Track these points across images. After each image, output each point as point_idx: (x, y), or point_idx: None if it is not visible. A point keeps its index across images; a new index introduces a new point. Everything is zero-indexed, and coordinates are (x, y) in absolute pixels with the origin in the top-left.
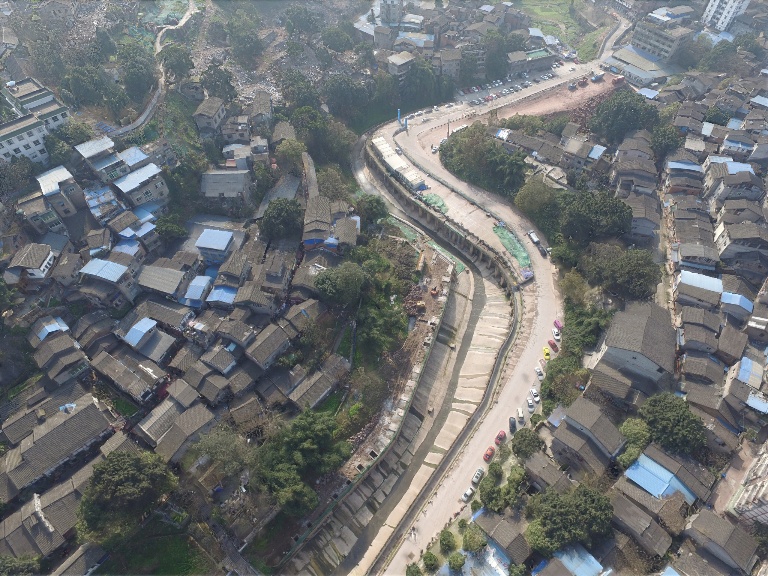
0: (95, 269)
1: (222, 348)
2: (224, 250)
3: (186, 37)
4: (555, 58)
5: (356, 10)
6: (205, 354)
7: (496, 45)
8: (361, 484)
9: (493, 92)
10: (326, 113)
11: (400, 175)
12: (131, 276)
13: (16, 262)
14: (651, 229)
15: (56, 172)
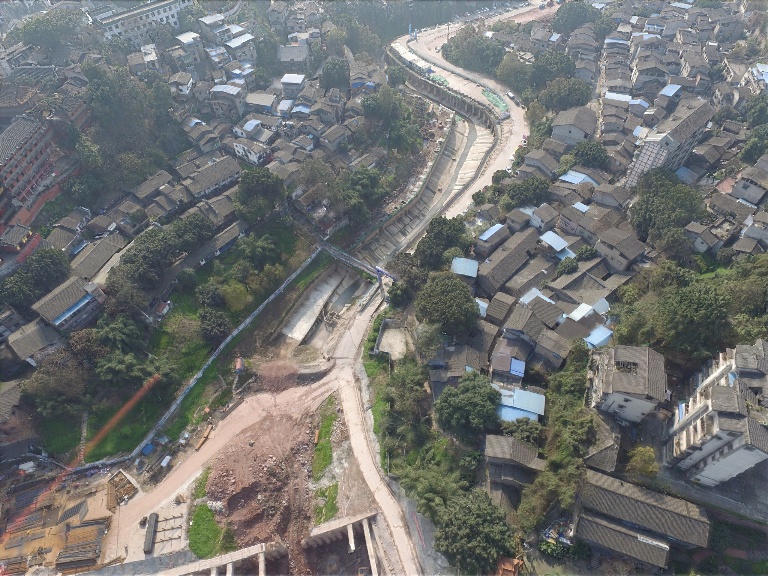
0: (220, 88)
1: (305, 135)
2: (300, 84)
3: None
4: None
5: None
6: (294, 139)
7: None
8: (396, 221)
9: (482, 15)
10: (356, 23)
11: (413, 65)
12: (241, 97)
13: (173, 80)
14: (590, 77)
15: (187, 34)
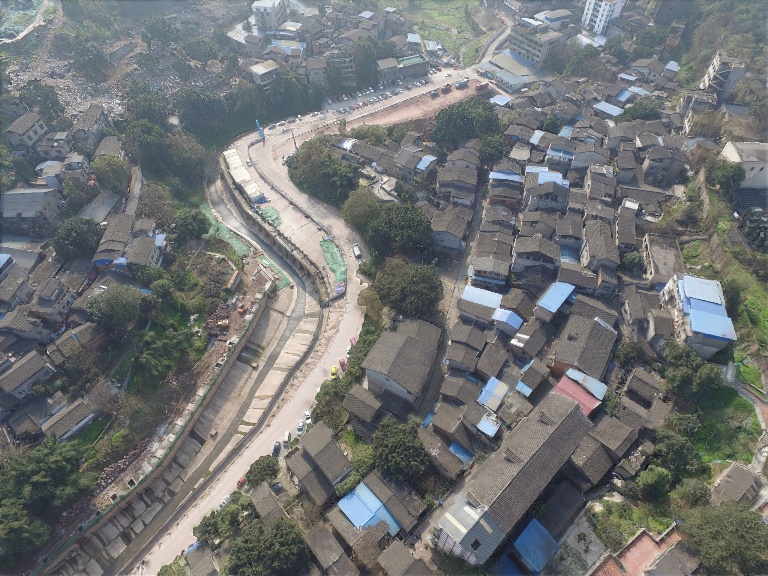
0: None
1: None
2: None
3: (25, 50)
4: (432, 64)
5: (234, 18)
6: None
7: (362, 52)
8: (119, 514)
9: (362, 100)
10: (173, 125)
11: (242, 188)
12: None
13: None
14: (456, 242)
15: None
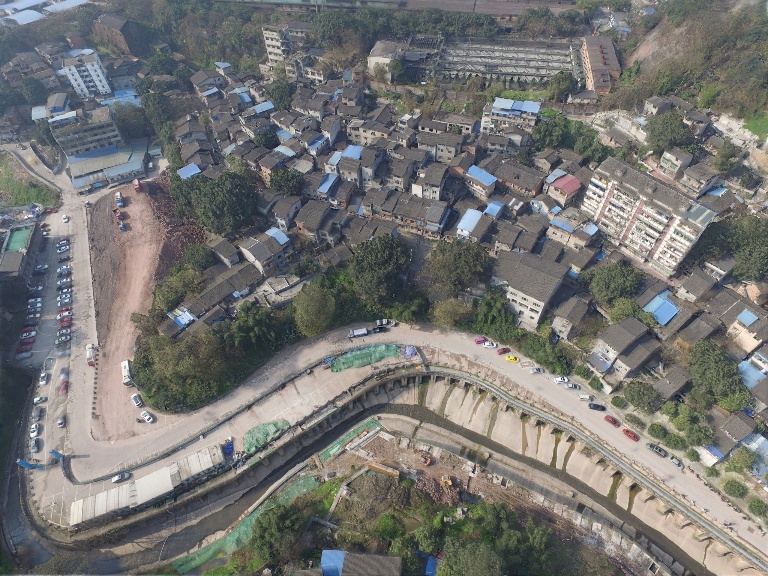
0: None
1: None
2: None
3: None
4: None
5: None
6: None
7: None
8: None
9: (52, 314)
10: None
11: (187, 481)
12: None
13: None
14: (396, 232)
15: None
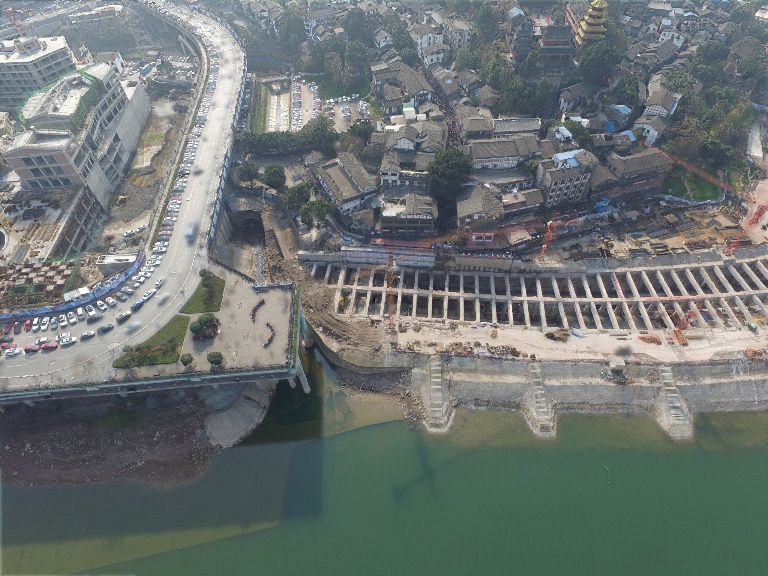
0: None
1: None
2: None
3: None
4: None
5: None
6: (697, 33)
7: None
8: None
9: None
10: None
11: None
12: None
13: None
14: None
15: None
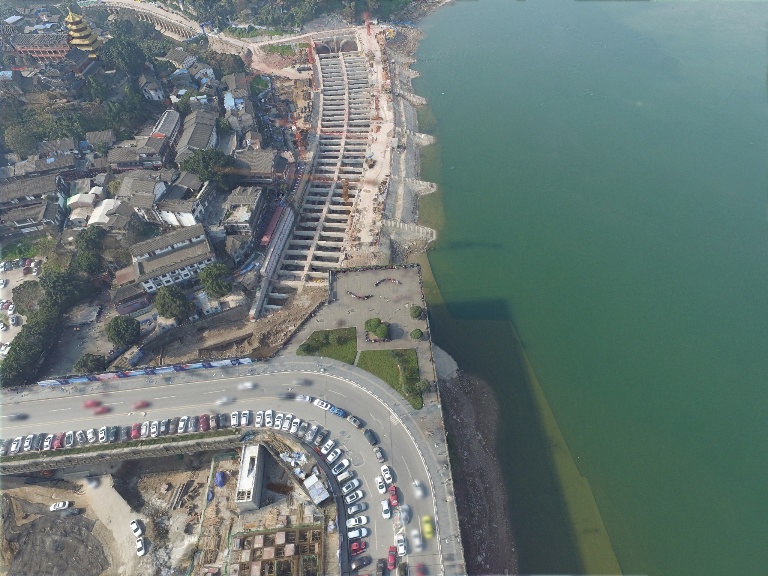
0: None
1: None
2: None
3: None
4: None
5: None
6: None
7: None
8: None
9: None
10: None
11: None
12: None
13: None
14: None
15: None
